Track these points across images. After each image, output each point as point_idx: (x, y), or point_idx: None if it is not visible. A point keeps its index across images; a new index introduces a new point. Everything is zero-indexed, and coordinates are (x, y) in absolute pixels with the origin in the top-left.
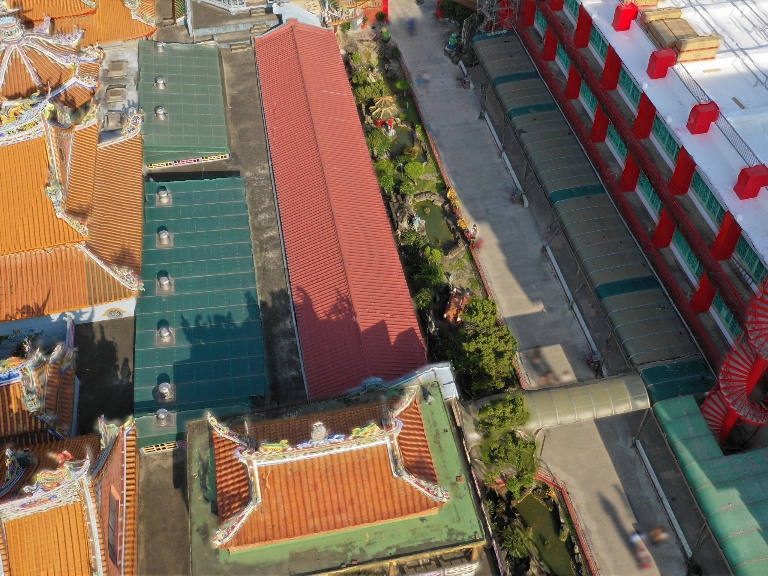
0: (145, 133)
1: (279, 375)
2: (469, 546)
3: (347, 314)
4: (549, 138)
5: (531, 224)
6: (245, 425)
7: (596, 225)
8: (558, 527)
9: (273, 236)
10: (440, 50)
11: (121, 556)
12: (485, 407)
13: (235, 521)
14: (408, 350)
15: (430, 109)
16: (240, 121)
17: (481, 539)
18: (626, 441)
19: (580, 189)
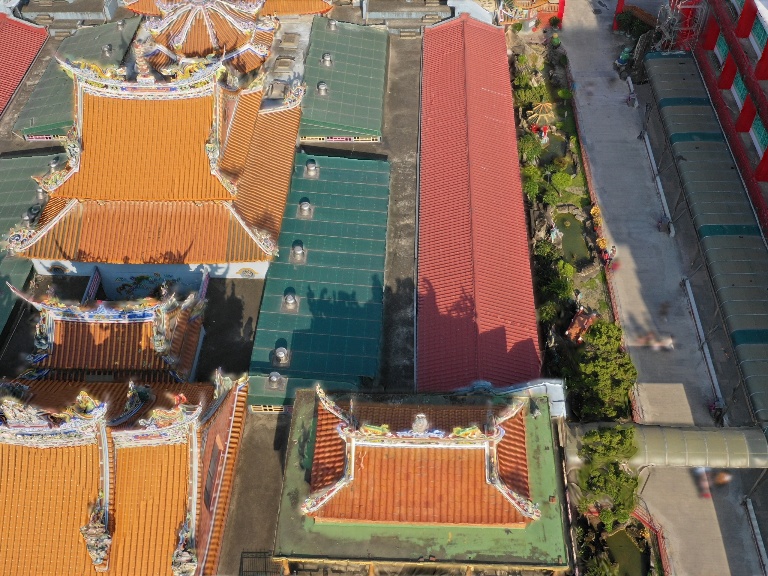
0: (305, 106)
1: (391, 361)
2: (550, 568)
3: (468, 313)
4: (709, 169)
5: (674, 255)
6: (351, 403)
7: (744, 267)
8: (646, 570)
9: (409, 224)
10: (609, 63)
11: (215, 503)
12: (592, 432)
13: (325, 493)
14: (523, 360)
15: (588, 121)
16: (396, 107)
17: (564, 564)
18: (736, 497)
19: (733, 227)
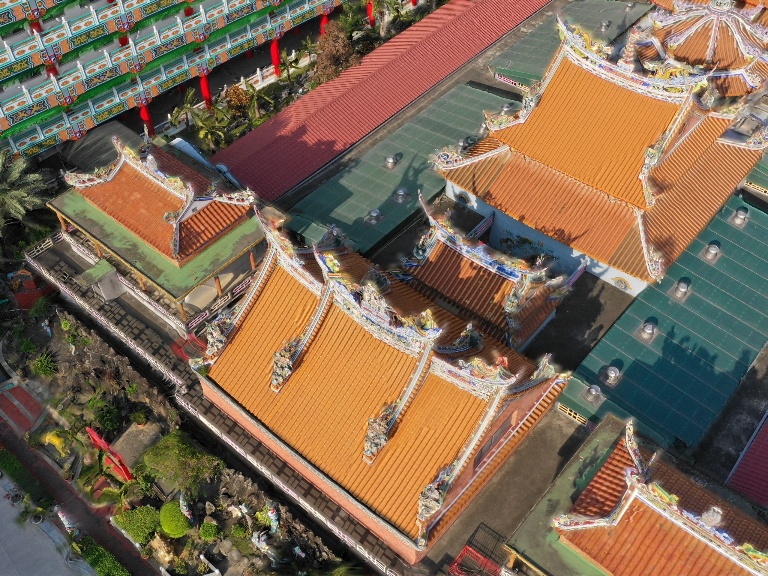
0: (767, 152)
1: (717, 440)
2: None
3: None
4: None
5: None
6: (653, 455)
7: None
8: None
9: None
10: None
11: (482, 466)
12: None
13: (583, 520)
14: None
15: None
16: None
17: None
18: None
19: None
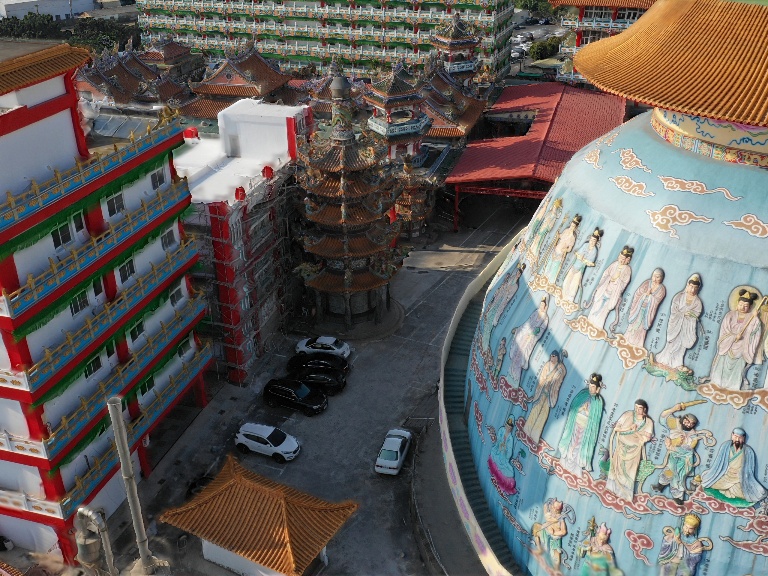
0: None
1: None
2: None
3: None
4: None
5: None
6: None
7: None
8: None
9: None
10: None
11: None
12: None
13: None
14: None
15: None
16: None
17: None
18: None
19: None
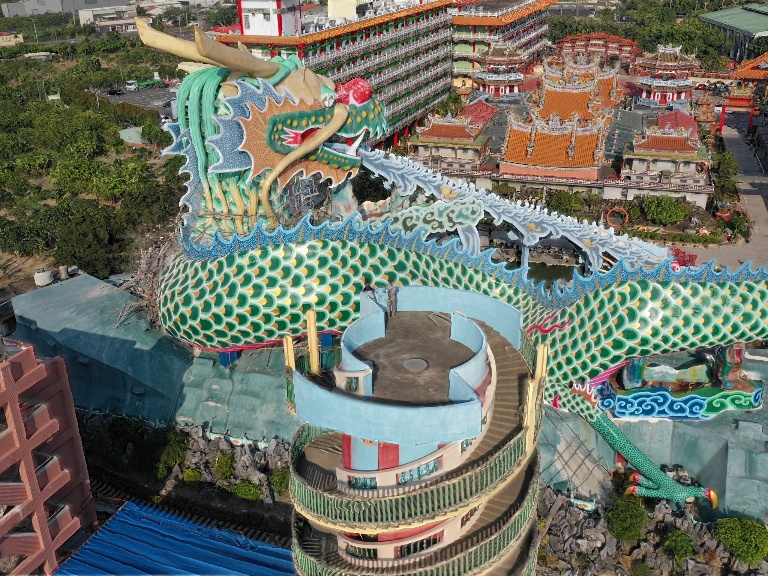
0: None
1: None
2: (704, 160)
3: None
4: None
5: None
6: None
7: None
8: (739, 215)
9: None
10: (744, 142)
11: None
12: None
13: None
14: None
15: None
16: None
17: None
18: None
19: None
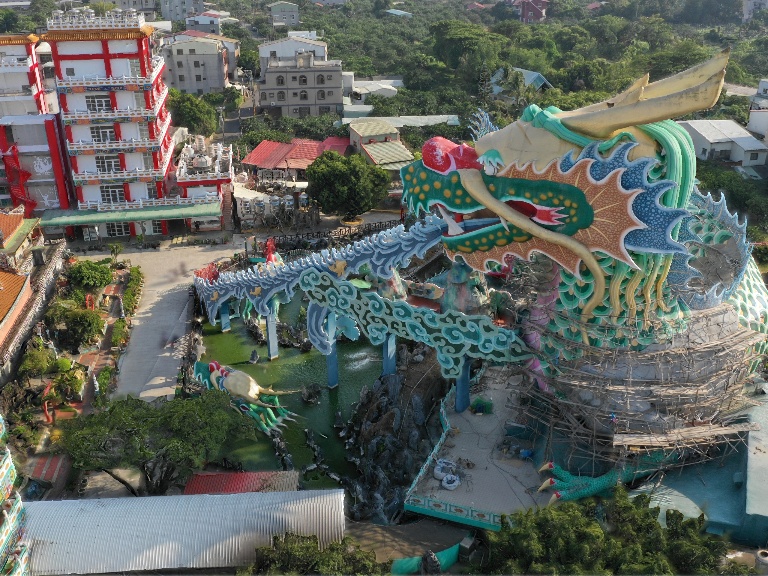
0: None
1: None
2: None
3: None
4: None
5: None
6: None
7: None
8: None
9: None
10: None
11: None
12: None
13: None
14: None
15: None
16: None
17: (40, 218)
18: None
19: None
